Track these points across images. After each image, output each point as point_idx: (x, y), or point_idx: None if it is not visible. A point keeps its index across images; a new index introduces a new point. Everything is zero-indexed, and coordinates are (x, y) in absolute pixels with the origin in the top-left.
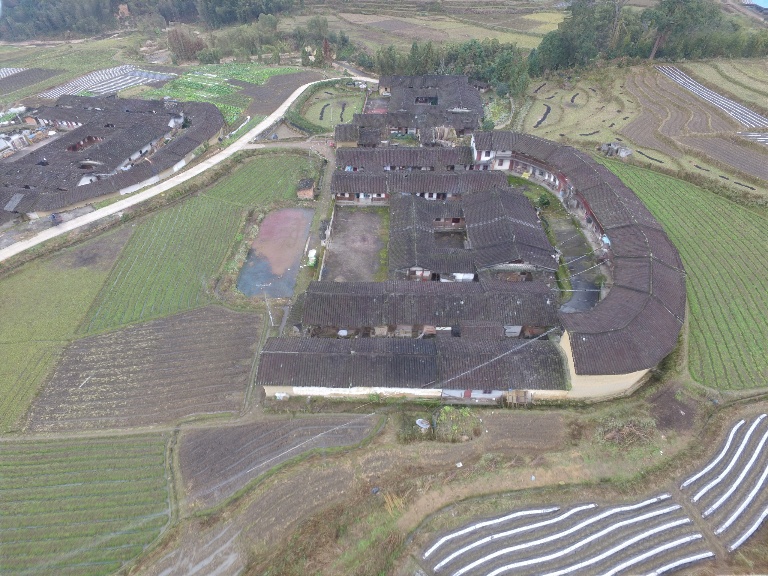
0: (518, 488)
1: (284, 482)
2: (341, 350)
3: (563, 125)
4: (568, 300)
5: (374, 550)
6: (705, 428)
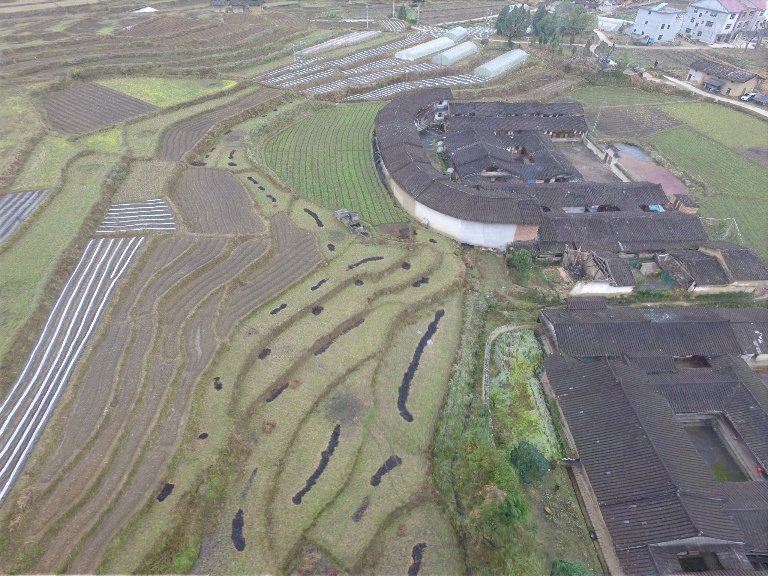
0: (465, 89)
1: (541, 96)
2: (546, 106)
3: (394, 306)
4: (435, 138)
5: (505, 83)
6: (397, 97)
